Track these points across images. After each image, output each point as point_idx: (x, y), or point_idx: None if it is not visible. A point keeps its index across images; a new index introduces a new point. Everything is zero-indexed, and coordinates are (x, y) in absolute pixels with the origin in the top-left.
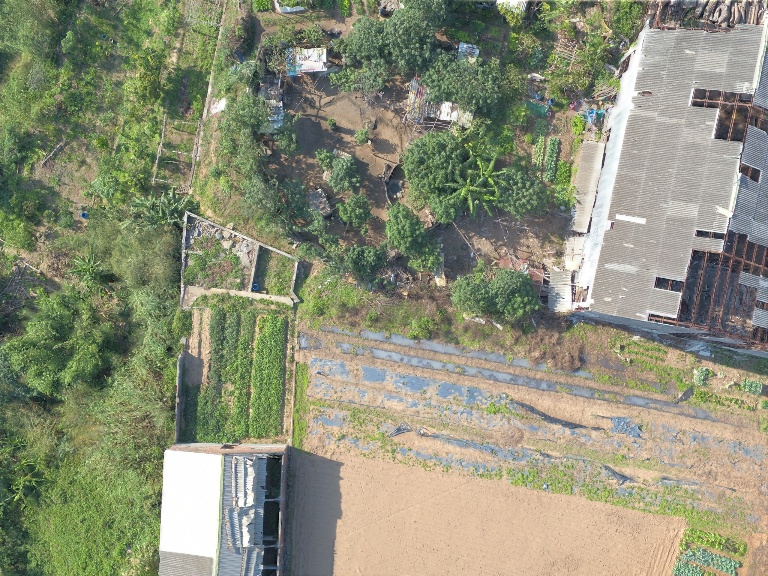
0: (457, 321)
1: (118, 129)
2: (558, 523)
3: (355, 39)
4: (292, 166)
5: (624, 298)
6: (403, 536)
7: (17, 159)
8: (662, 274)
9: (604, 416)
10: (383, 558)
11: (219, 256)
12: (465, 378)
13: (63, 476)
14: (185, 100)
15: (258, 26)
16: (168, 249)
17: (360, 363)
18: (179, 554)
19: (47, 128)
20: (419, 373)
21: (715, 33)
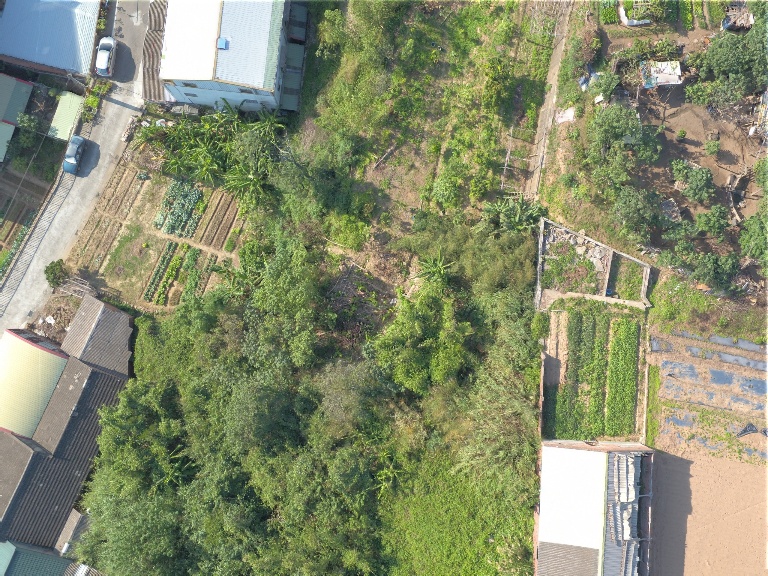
0: None
1: (446, 134)
2: None
3: (719, 54)
4: (639, 175)
5: None
6: (749, 532)
7: (352, 162)
8: None
9: None
10: (730, 552)
11: (574, 261)
12: None
13: (426, 468)
14: (520, 108)
15: (605, 38)
16: (528, 254)
17: (708, 366)
18: (561, 545)
19: (378, 132)
20: (764, 377)
21: None
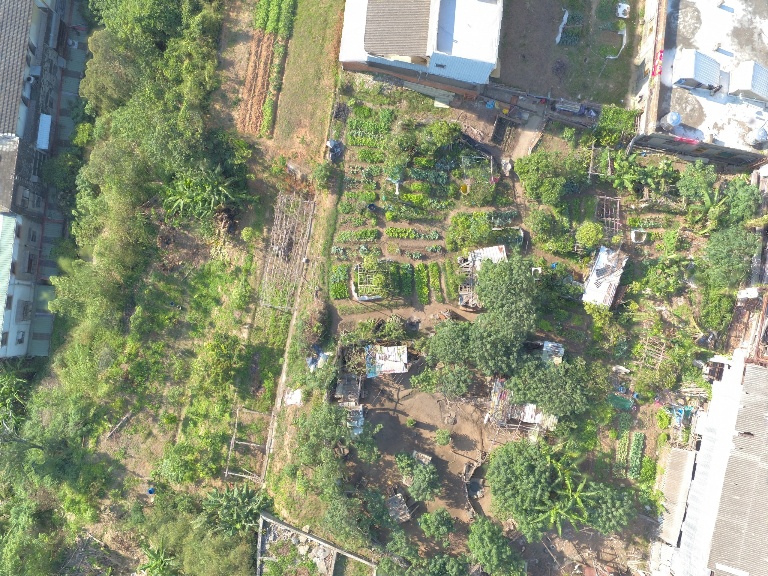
0: None
1: (185, 399)
2: None
3: (439, 348)
4: (369, 463)
5: None
6: None
7: (83, 433)
8: None
9: None
10: None
11: (295, 562)
12: None
13: None
14: (256, 379)
15: (335, 315)
16: (243, 557)
17: None
18: None
19: (113, 399)
20: None
21: None
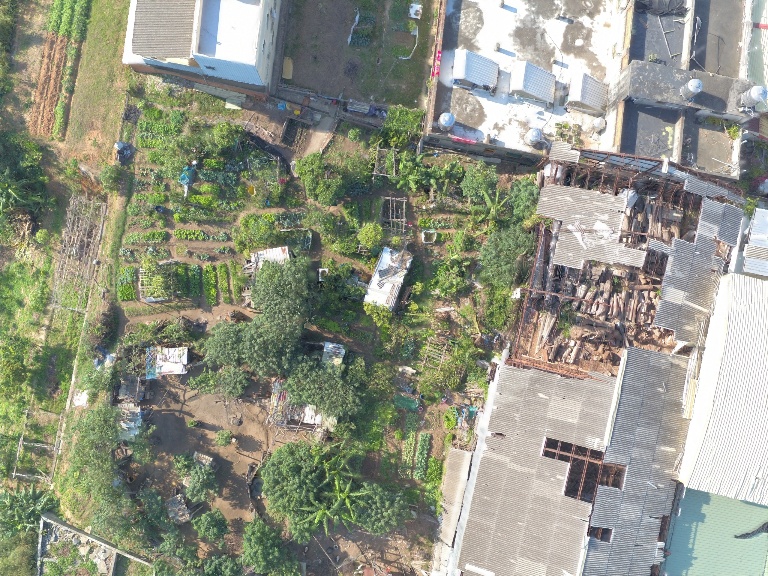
0: None
1: None
2: None
3: (212, 349)
4: (154, 464)
5: None
6: None
7: None
8: None
9: None
10: None
11: (76, 563)
12: None
13: None
14: (53, 380)
15: (122, 316)
16: (22, 558)
17: None
18: None
19: None
20: None
21: (569, 379)
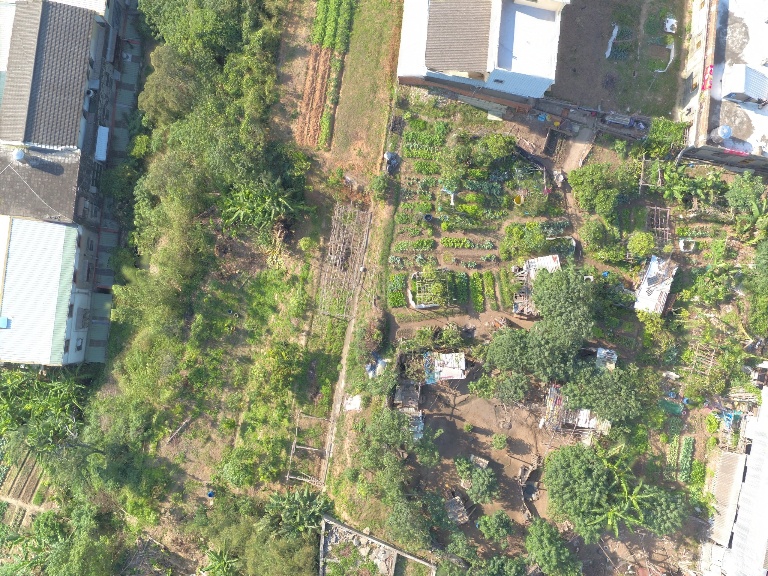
0: None
1: (243, 405)
2: None
3: (498, 355)
4: (427, 467)
5: None
6: None
7: (144, 438)
8: None
9: None
10: None
11: (356, 563)
12: None
13: None
14: (314, 385)
15: (393, 323)
16: (307, 559)
17: None
18: None
19: (173, 404)
20: None
21: None
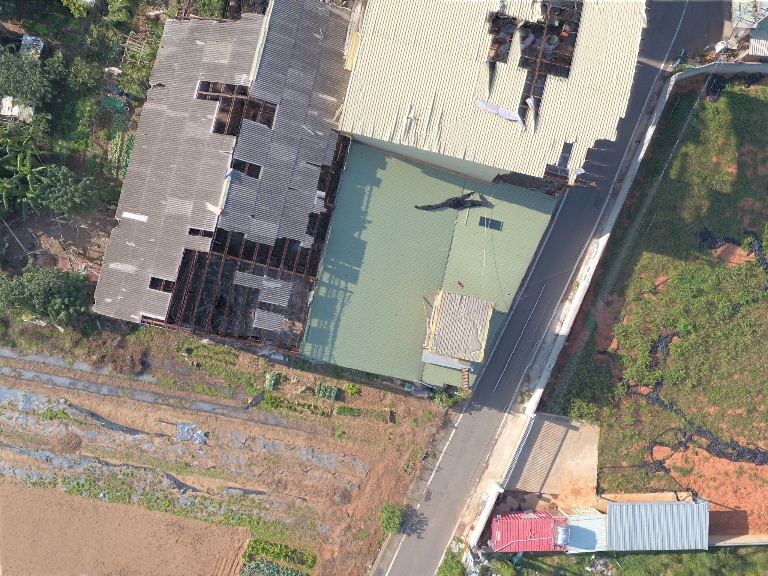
0: (15, 323)
1: None
2: (114, 533)
3: None
4: None
5: (122, 299)
6: None
7: None
8: (157, 274)
9: (168, 422)
10: None
11: None
12: (22, 382)
13: None
14: None
15: None
16: None
17: None
18: None
19: None
20: None
21: (222, 23)
